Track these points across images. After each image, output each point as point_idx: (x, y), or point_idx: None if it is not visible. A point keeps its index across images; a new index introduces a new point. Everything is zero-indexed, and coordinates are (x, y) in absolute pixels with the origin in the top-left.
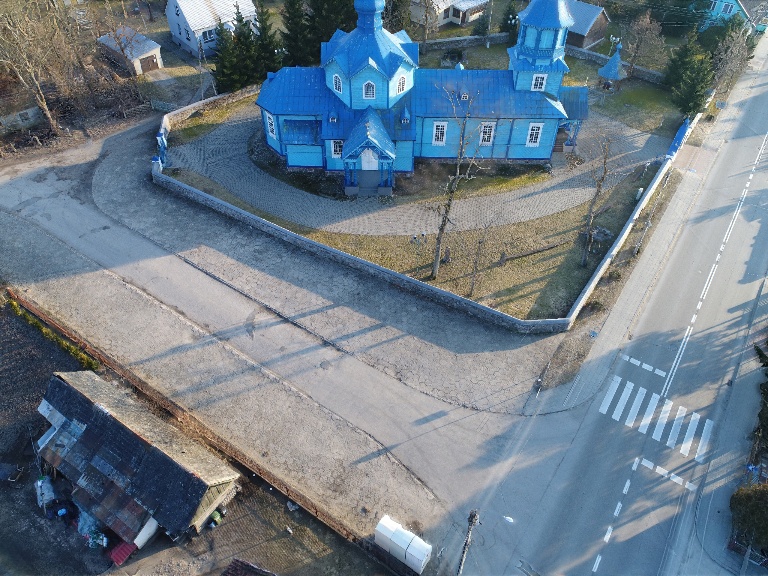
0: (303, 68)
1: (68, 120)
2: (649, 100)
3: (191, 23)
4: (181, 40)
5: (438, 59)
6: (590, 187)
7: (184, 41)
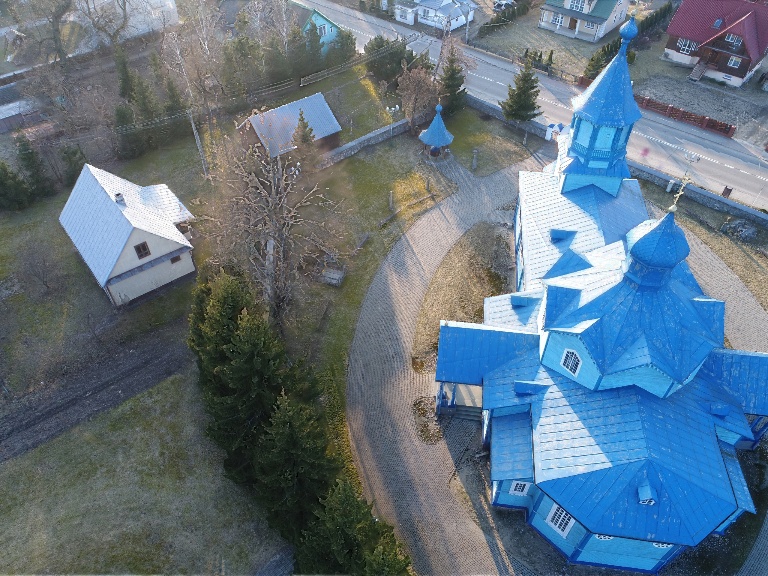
0: (643, 425)
1: None
2: (464, 135)
3: None
4: None
5: (311, 284)
6: (654, 215)
7: None
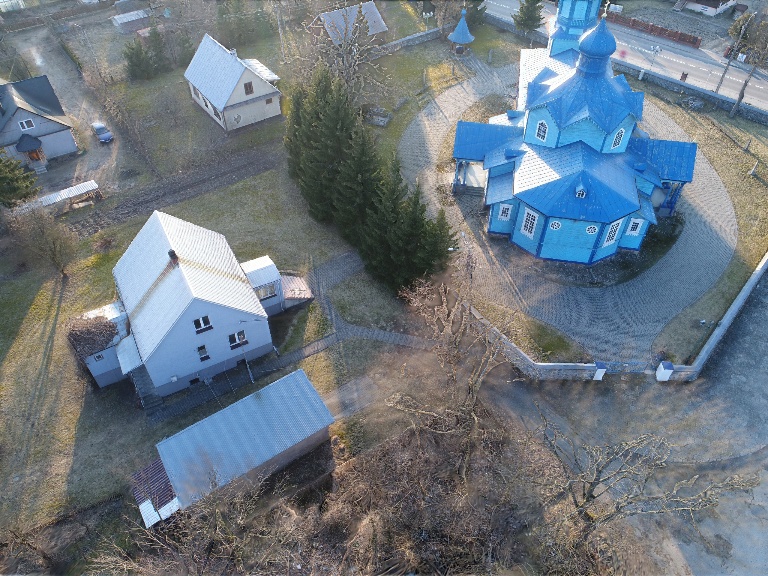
0: (583, 157)
1: (507, 540)
2: (483, 42)
3: (254, 310)
4: (206, 368)
5: None
6: None
7: (218, 361)
